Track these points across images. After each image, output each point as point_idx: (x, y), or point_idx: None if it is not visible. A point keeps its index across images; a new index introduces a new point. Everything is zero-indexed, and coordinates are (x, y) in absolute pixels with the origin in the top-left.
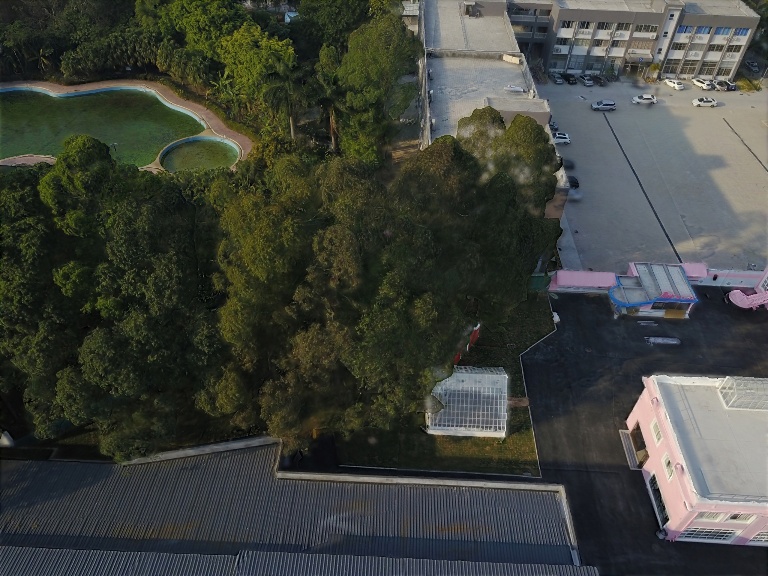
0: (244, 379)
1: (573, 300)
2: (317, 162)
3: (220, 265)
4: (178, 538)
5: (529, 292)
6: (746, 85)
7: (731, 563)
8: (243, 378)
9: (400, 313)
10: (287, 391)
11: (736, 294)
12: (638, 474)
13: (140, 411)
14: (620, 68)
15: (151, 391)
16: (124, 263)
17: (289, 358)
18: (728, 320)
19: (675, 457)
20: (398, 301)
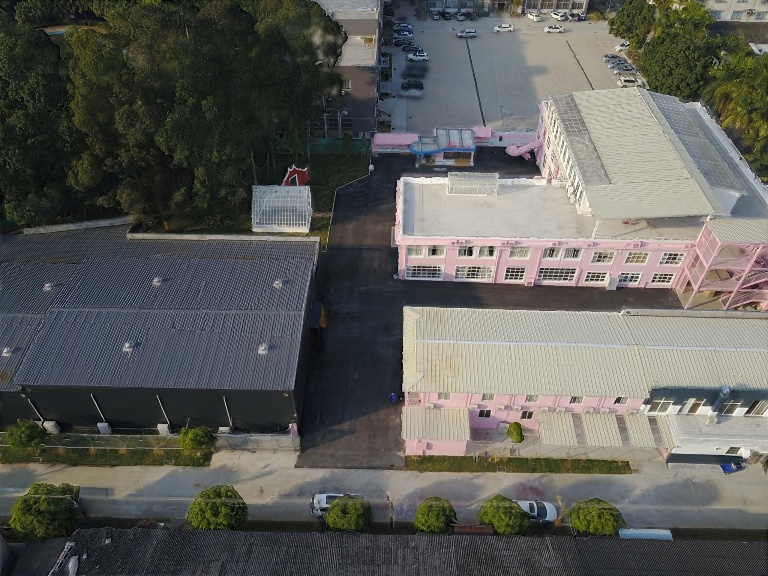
0: (95, 160)
1: (389, 157)
2: None
3: (71, 78)
4: None
5: (356, 153)
6: (596, 16)
7: (439, 290)
8: (95, 159)
9: (192, 110)
10: (122, 165)
11: (511, 147)
12: (395, 249)
13: (33, 193)
14: (490, 5)
15: (42, 182)
16: (8, 77)
17: (127, 149)
18: (503, 166)
19: (398, 218)
20: (189, 100)
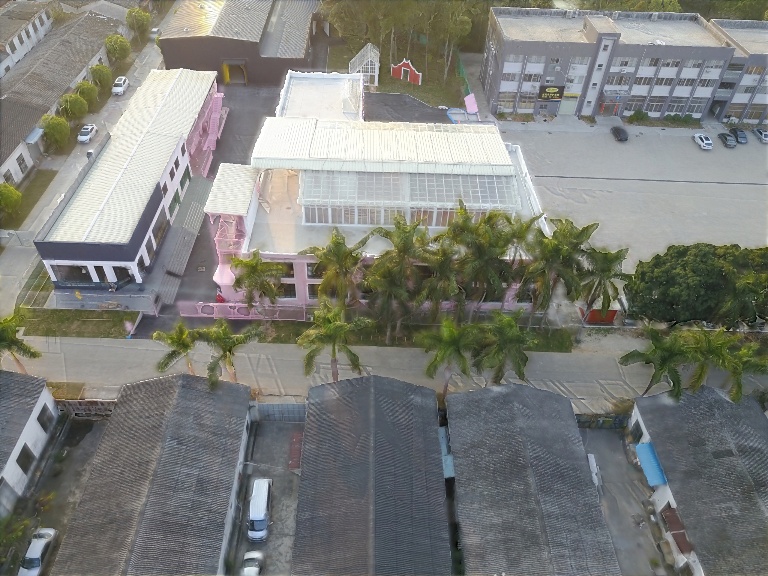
0: None
1: None
2: (520, 3)
3: None
4: (287, 1)
5: None
6: None
7: None
8: None
9: None
10: None
11: None
12: None
13: None
14: None
15: None
16: None
17: None
18: None
19: None
20: None
